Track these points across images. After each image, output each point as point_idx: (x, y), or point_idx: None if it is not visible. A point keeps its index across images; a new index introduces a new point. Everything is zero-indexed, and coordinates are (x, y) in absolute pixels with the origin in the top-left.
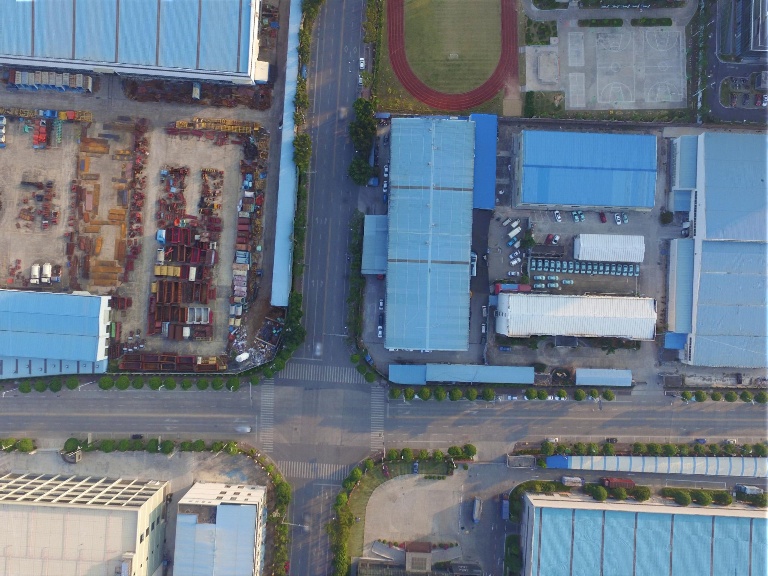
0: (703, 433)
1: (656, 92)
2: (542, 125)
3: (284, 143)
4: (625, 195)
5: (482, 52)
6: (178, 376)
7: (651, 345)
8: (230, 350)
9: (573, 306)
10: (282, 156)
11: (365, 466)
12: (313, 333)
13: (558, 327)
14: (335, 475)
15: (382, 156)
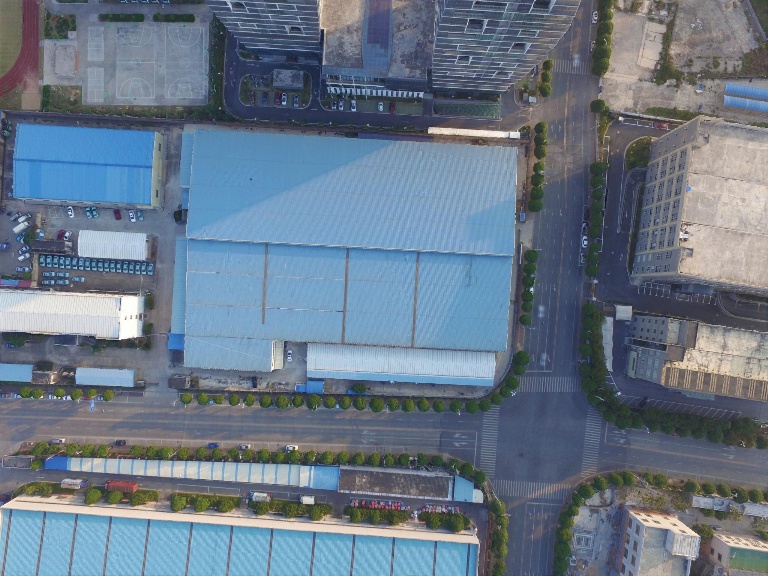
0: (217, 437)
1: (177, 88)
2: (58, 119)
3: None
4: (121, 191)
5: (1, 45)
6: None
7: (165, 345)
8: None
9: (34, 302)
10: None
11: None
12: None
13: (19, 324)
14: None
15: None
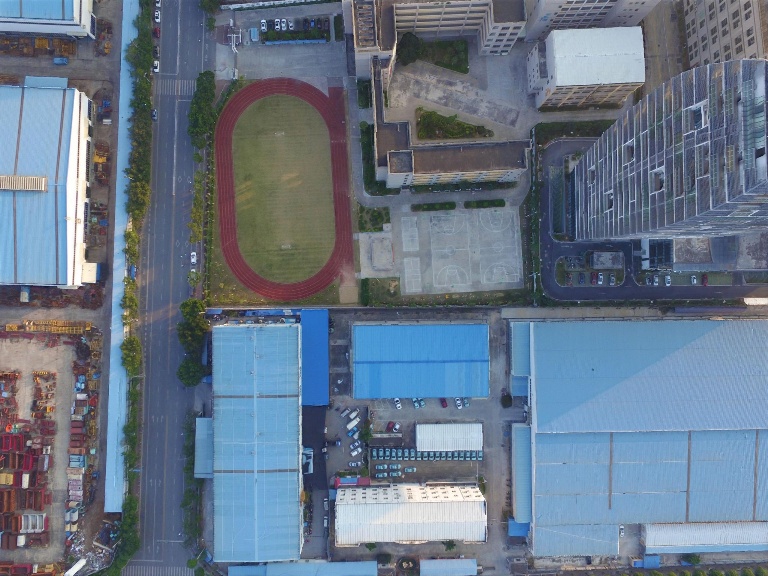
0: None
1: (492, 273)
2: (379, 312)
3: (113, 346)
4: (459, 386)
5: (316, 240)
6: None
7: (498, 529)
8: (68, 556)
9: (402, 512)
10: (111, 359)
11: None
12: (153, 534)
13: (387, 534)
14: None
15: None
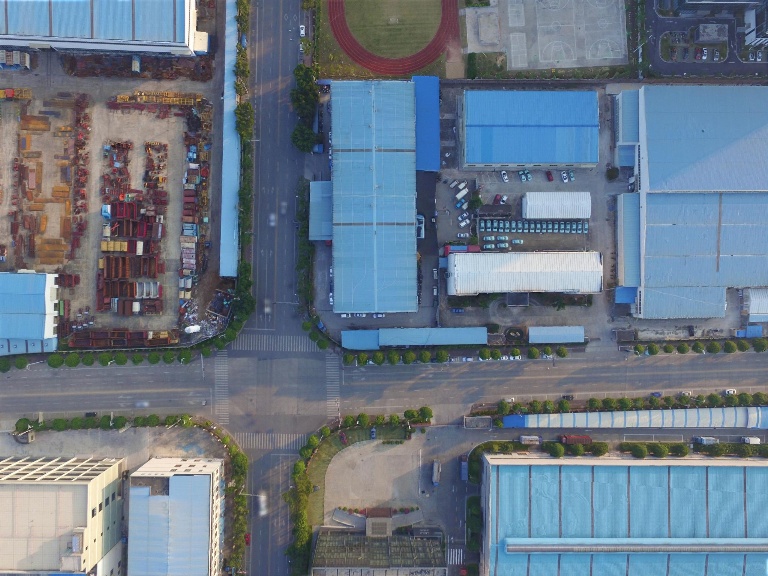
0: (658, 387)
1: (597, 49)
2: (485, 86)
3: (226, 113)
4: (569, 151)
5: (422, 16)
6: (129, 352)
7: (603, 301)
8: (181, 324)
9: (519, 262)
10: (225, 126)
11: (321, 433)
12: (264, 303)
13: (505, 284)
14: (293, 445)
15: (326, 123)
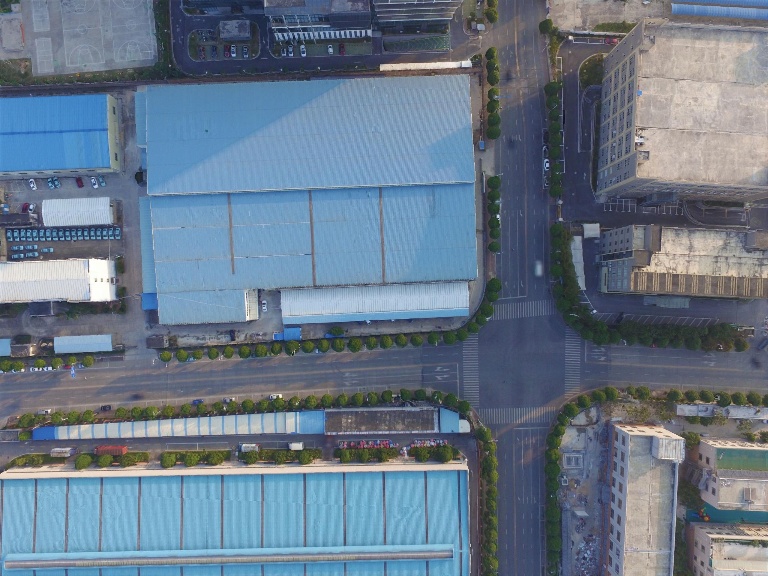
0: (201, 394)
1: (126, 51)
2: (11, 93)
3: None
4: (79, 157)
5: None
6: None
7: (140, 308)
8: None
9: (3, 272)
10: None
11: None
12: None
13: None
14: None
15: None
